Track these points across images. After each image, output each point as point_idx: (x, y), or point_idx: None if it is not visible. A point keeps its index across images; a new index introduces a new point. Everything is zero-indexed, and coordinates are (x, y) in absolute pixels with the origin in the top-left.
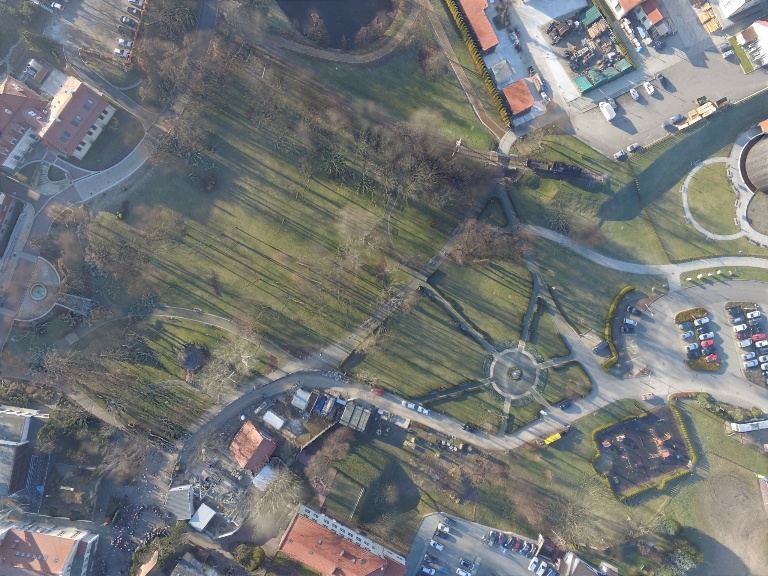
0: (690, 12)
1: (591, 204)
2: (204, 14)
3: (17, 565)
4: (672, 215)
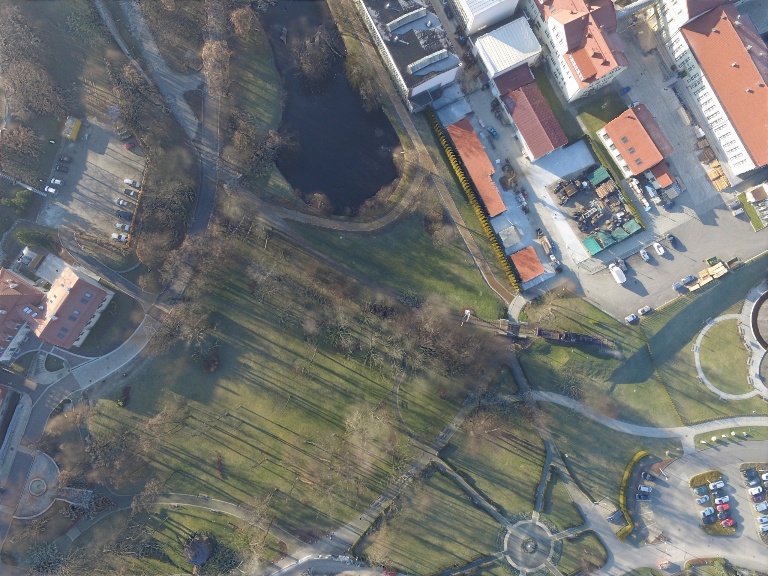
0: (699, 168)
1: (603, 370)
2: (203, 187)
3: None
4: (684, 375)
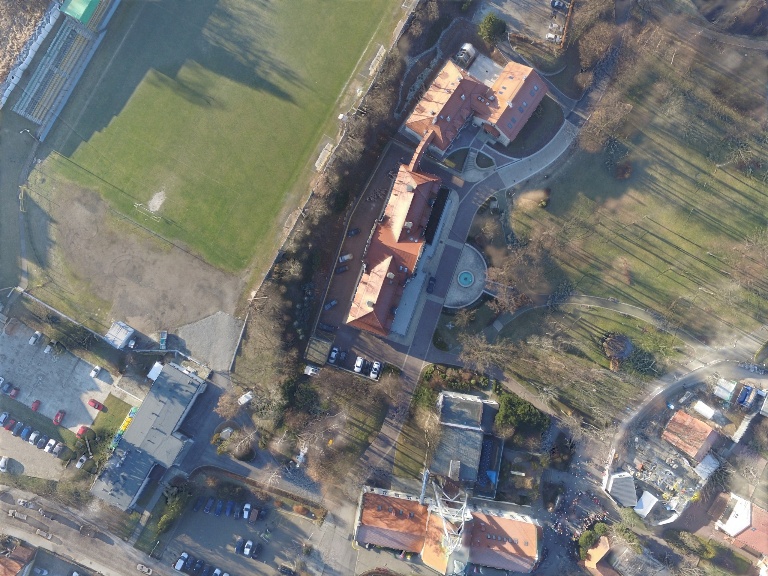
0: None
1: None
2: None
3: (493, 547)
4: None
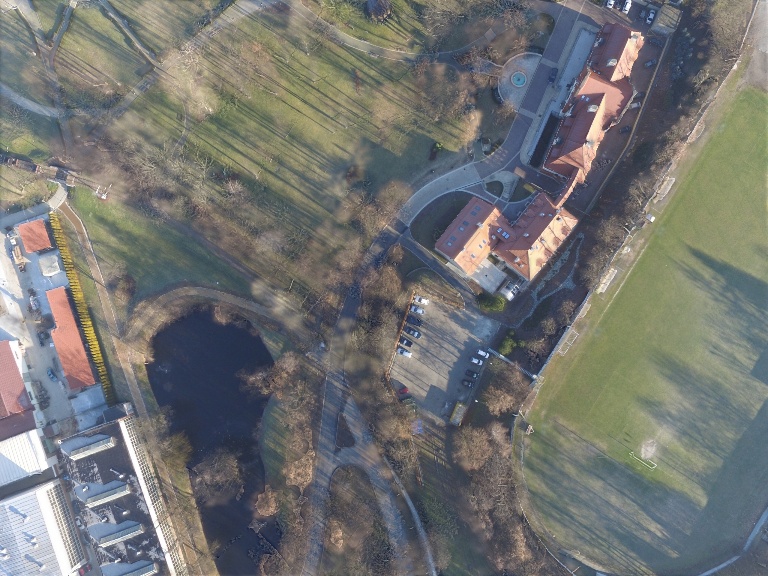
0: None
1: None
2: (343, 346)
3: None
4: None
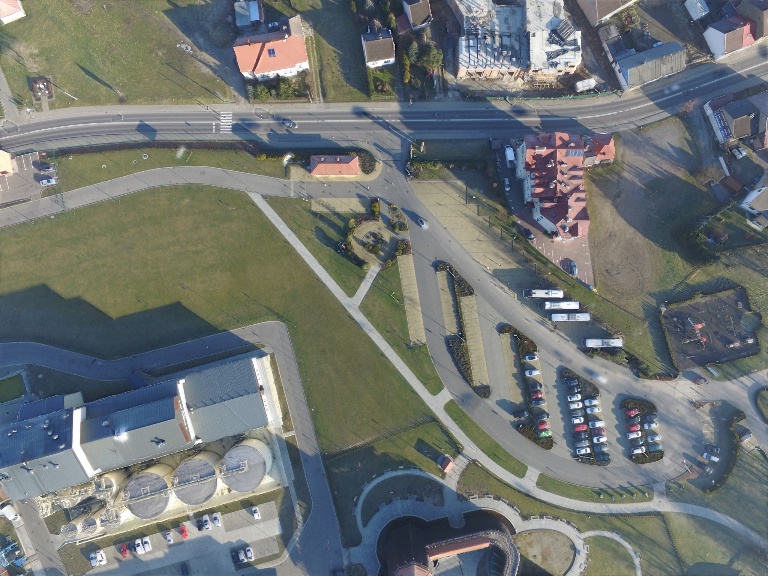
0: None
1: None
2: None
3: None
4: (654, 563)
